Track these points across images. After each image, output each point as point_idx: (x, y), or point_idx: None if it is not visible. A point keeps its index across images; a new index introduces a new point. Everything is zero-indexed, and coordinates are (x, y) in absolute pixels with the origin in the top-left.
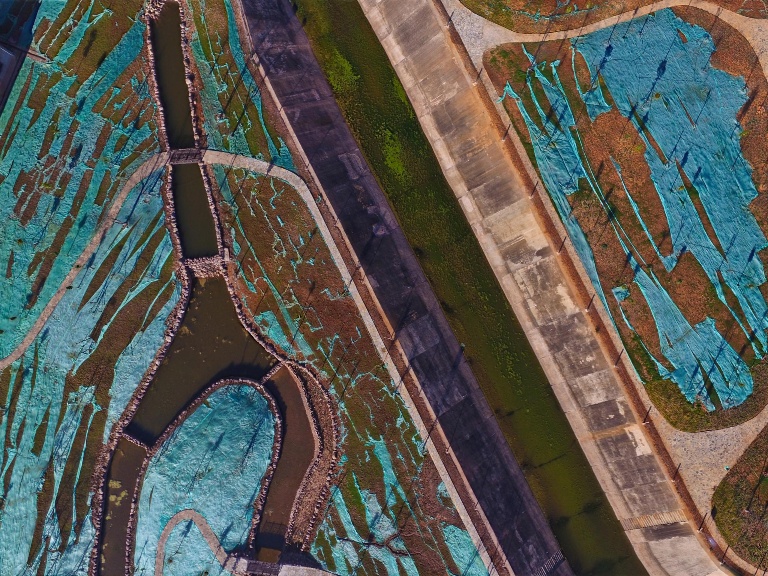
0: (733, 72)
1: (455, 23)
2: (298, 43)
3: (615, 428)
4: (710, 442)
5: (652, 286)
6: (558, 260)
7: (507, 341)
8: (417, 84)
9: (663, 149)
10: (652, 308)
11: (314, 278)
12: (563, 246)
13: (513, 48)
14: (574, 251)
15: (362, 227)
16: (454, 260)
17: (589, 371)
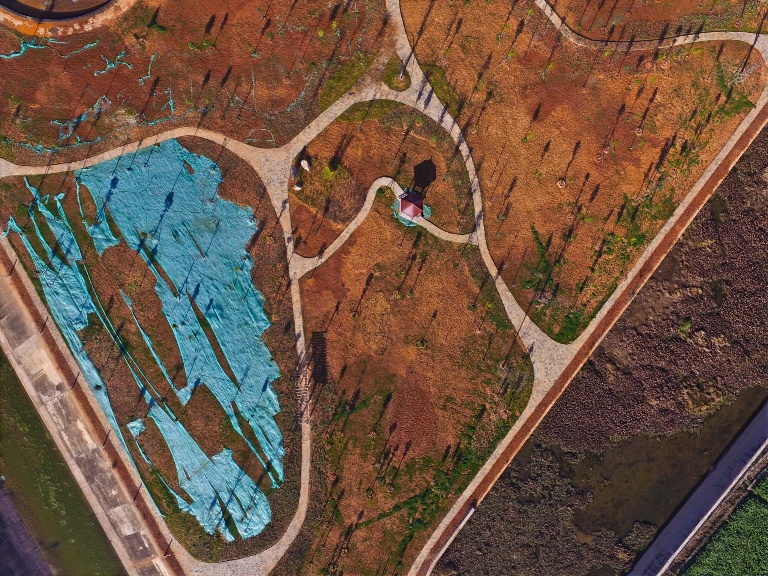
0: (241, 203)
1: None
2: None
3: (146, 559)
4: (231, 572)
5: (167, 419)
6: (72, 396)
7: (49, 471)
8: None
9: (174, 281)
10: (168, 441)
11: None
12: (76, 382)
13: (15, 181)
14: (88, 386)
15: None
16: None
17: (117, 504)
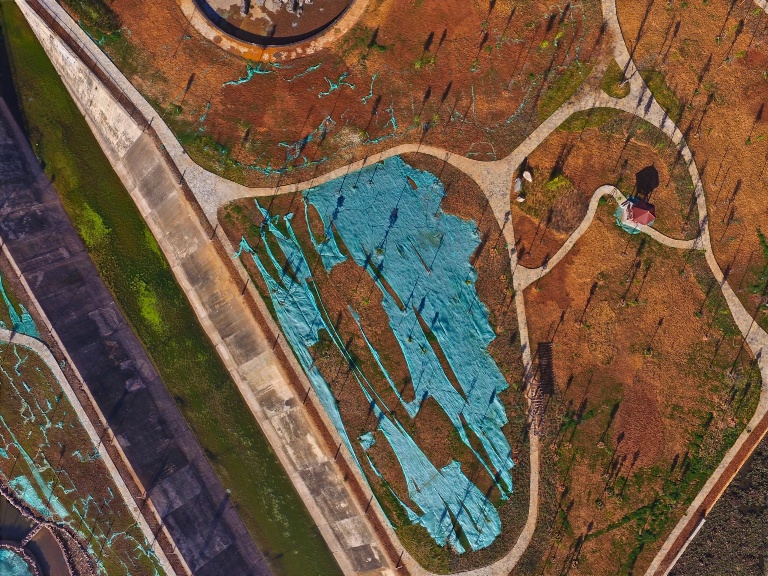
0: (464, 216)
1: (188, 181)
2: (45, 201)
3: (374, 571)
4: None
5: (396, 432)
6: (303, 411)
7: (272, 484)
8: (165, 236)
9: (400, 296)
10: (398, 454)
11: (64, 441)
12: (307, 397)
13: (246, 203)
14: (319, 401)
15: (113, 385)
16: (215, 407)
17: (345, 516)
